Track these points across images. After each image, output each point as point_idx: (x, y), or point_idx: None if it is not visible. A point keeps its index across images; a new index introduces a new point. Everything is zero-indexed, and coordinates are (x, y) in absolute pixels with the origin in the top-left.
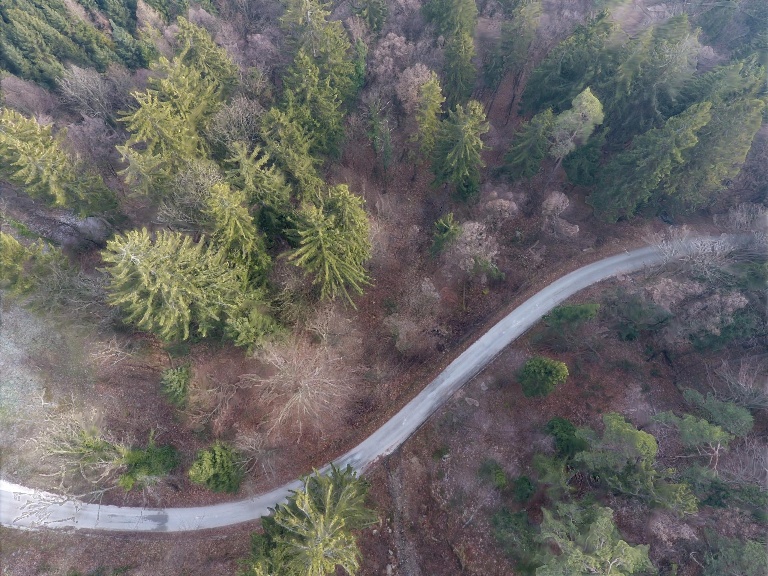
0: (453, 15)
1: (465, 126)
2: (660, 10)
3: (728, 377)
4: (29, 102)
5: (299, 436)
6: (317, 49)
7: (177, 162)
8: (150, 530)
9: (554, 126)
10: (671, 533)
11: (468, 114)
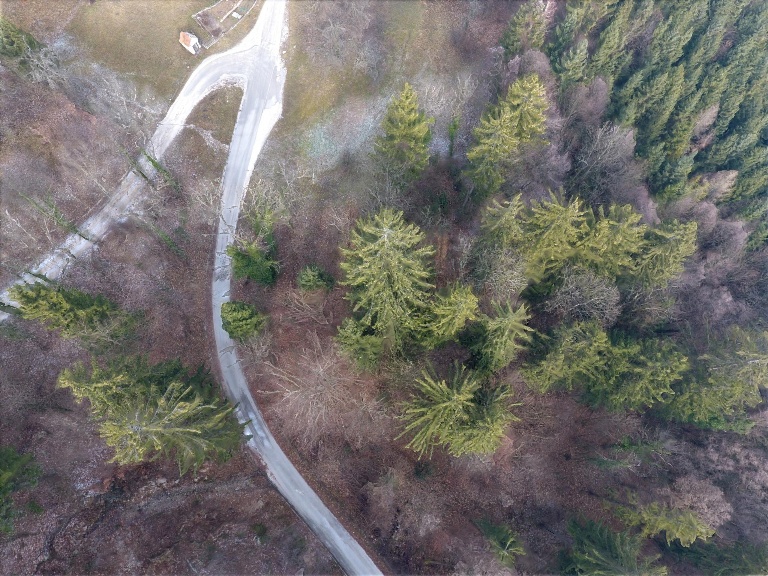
0: None
1: None
2: None
3: None
4: (583, 104)
5: None
6: (717, 372)
7: None
8: None
9: None
10: None
11: None
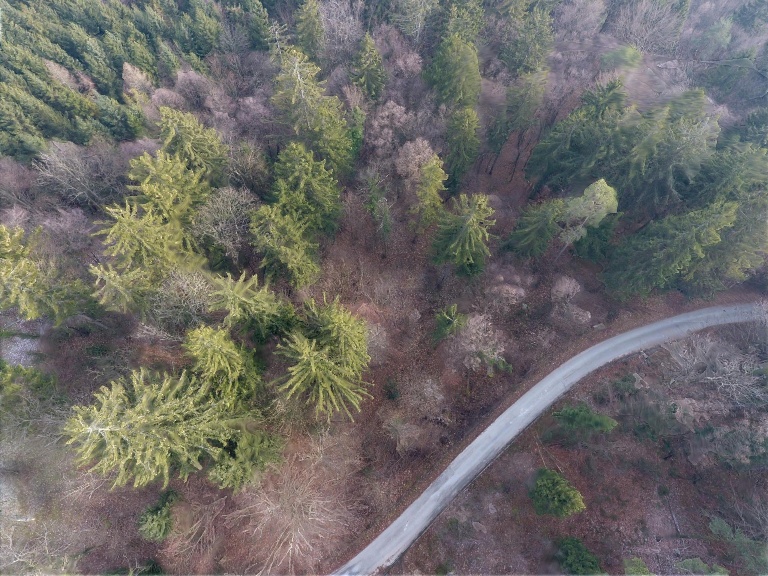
0: (455, 84)
1: (470, 220)
2: (671, 67)
3: (760, 514)
4: (5, 184)
5: None
6: (312, 123)
7: (160, 264)
8: None
9: None
10: None
11: (473, 207)
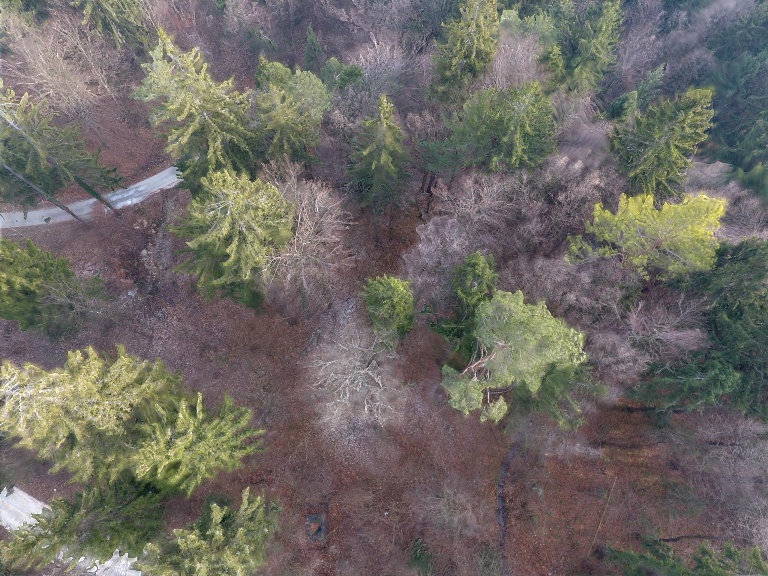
0: None
1: None
2: None
3: None
4: None
5: None
6: None
7: None
8: None
9: None
10: None
11: None
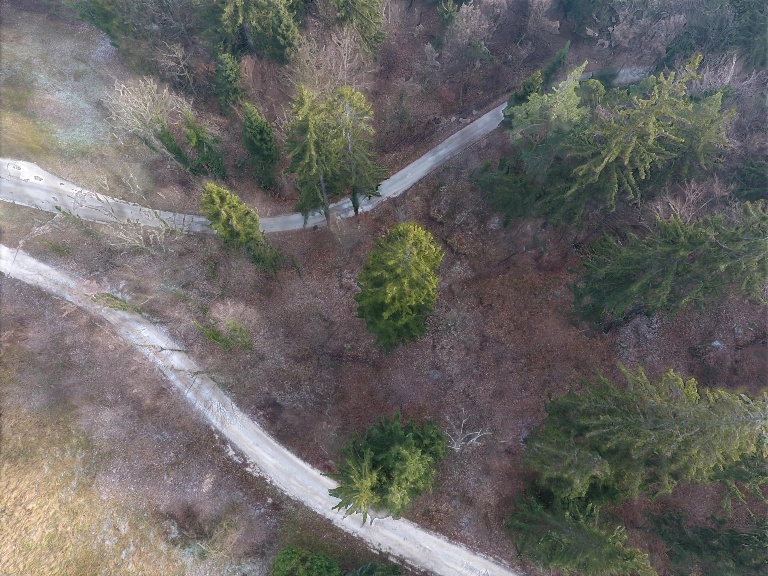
0: None
1: None
2: None
3: None
4: None
5: None
6: None
7: None
8: (200, 231)
9: None
10: (608, 113)
11: None
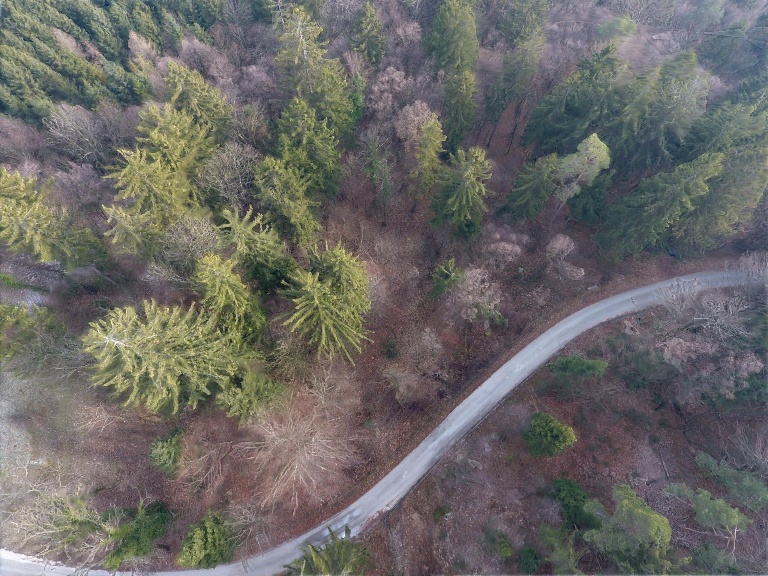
0: (454, 49)
1: (467, 173)
2: (665, 38)
3: (743, 445)
4: (16, 143)
5: (295, 508)
6: (314, 86)
7: (168, 213)
8: None
9: (559, 169)
10: None
11: (470, 161)
